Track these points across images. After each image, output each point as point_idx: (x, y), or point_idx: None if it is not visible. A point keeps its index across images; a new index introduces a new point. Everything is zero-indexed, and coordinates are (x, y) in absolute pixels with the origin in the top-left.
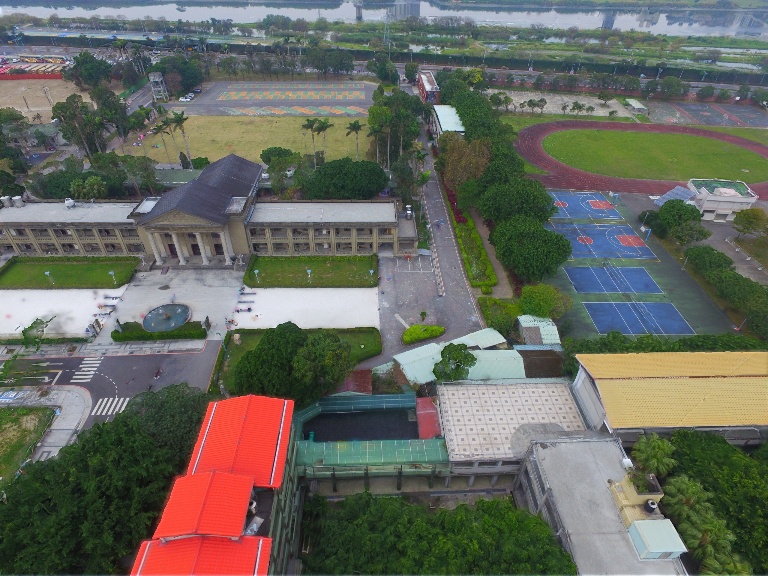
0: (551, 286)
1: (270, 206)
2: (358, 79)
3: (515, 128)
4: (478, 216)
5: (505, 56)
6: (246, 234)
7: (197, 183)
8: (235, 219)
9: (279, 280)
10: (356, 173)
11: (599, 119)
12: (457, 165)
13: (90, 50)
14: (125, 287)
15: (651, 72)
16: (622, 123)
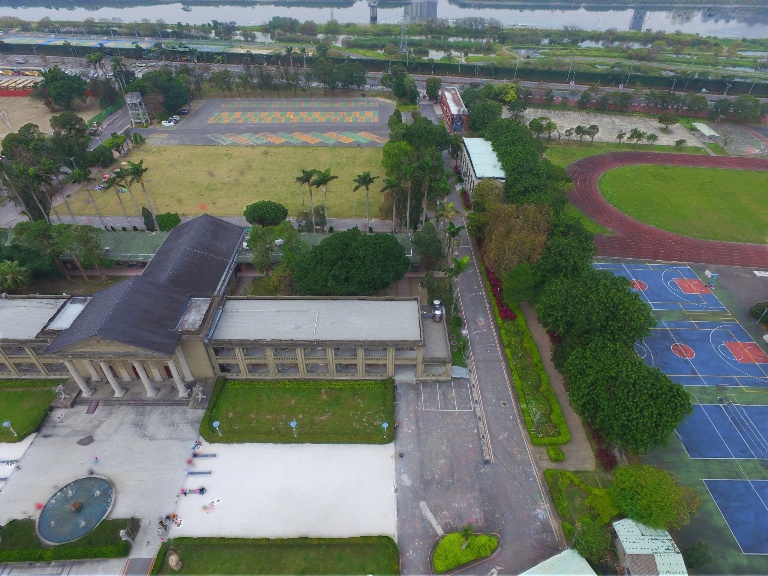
0: (666, 475)
1: (245, 306)
2: (371, 95)
3: (562, 163)
4: (529, 307)
5: (539, 66)
6: (208, 354)
7: (140, 281)
8: (190, 339)
9: (252, 427)
10: (365, 257)
11: (663, 150)
12: (504, 243)
13: (61, 65)
14: (30, 439)
15: (714, 86)
16: (692, 155)
